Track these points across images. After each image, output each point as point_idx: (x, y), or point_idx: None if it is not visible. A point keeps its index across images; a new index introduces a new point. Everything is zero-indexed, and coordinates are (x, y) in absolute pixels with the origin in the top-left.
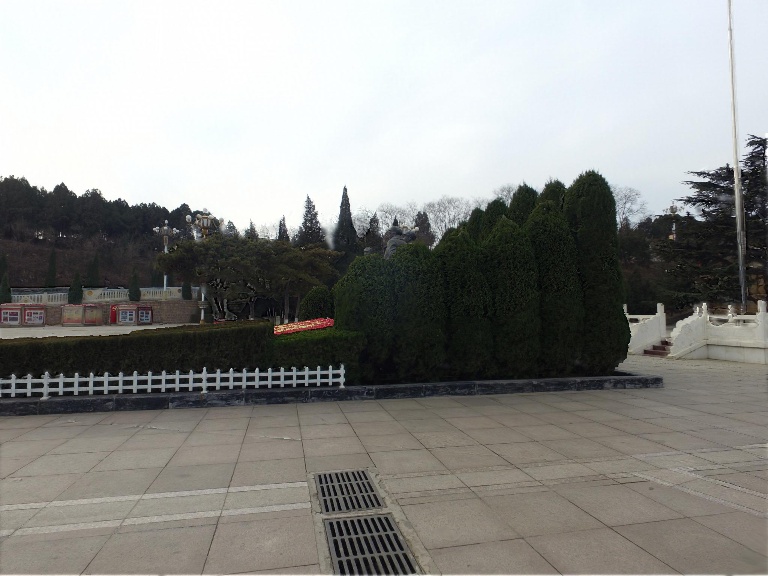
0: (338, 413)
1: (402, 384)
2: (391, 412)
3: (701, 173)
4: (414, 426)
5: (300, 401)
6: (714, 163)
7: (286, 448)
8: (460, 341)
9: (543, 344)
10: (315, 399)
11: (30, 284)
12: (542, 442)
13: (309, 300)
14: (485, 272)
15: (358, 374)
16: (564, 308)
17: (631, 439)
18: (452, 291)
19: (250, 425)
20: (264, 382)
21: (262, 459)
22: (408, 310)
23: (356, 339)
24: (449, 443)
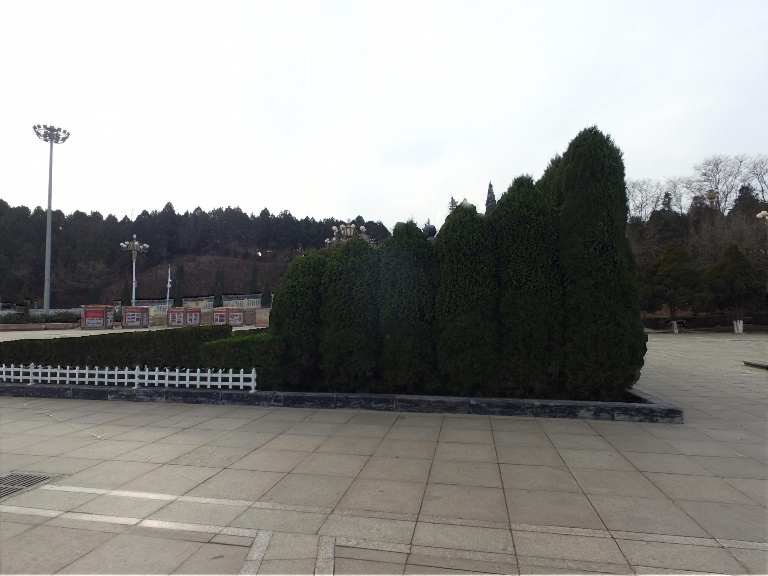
0: (209, 417)
1: (318, 393)
2: (255, 421)
3: None
4: (228, 439)
5: (212, 402)
6: None
7: (69, 446)
8: (389, 348)
9: (502, 355)
10: (225, 401)
11: (235, 292)
12: (291, 475)
13: None
14: (429, 268)
15: (280, 379)
16: (525, 309)
17: (404, 488)
18: (382, 291)
19: (113, 421)
20: (183, 382)
21: (25, 453)
22: (328, 313)
23: (272, 343)
24: (200, 461)
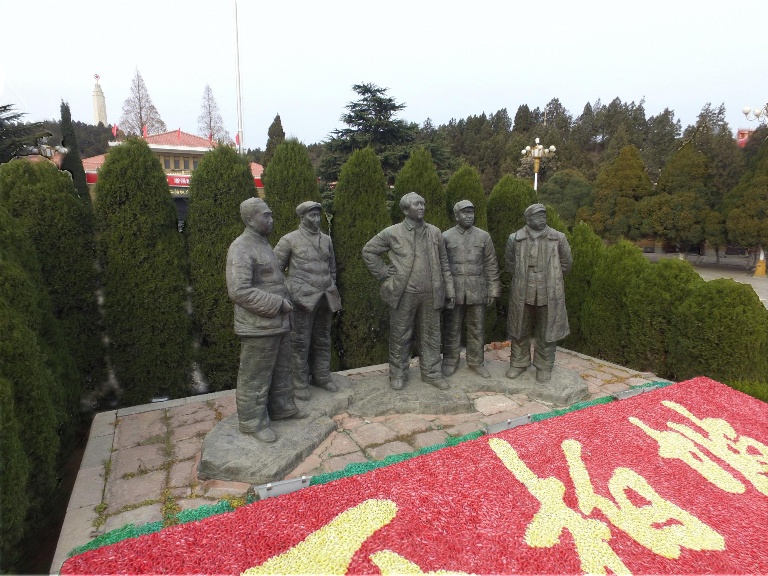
0: None
1: None
2: None
3: None
4: None
5: None
6: None
7: None
8: None
9: None
10: None
11: None
12: None
13: None
14: None
15: None
16: None
17: None
18: None
19: None
20: None
21: None
22: None
23: None
24: None
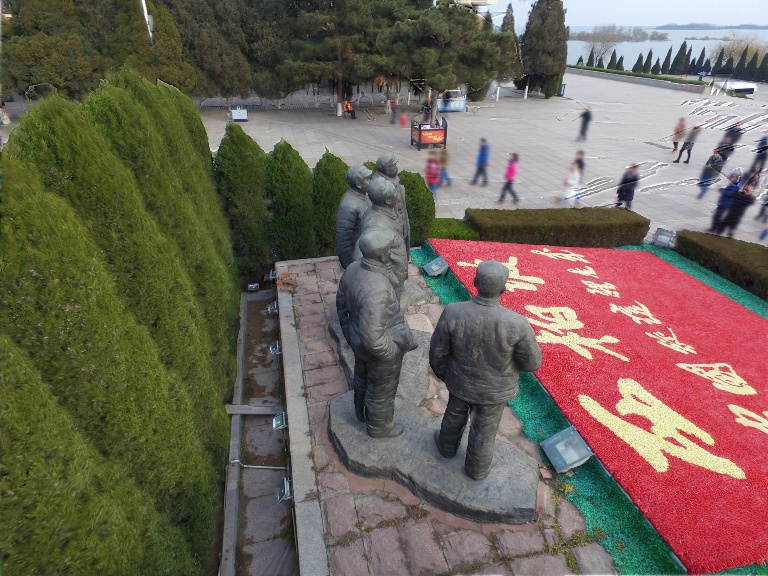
0: None
1: None
2: None
3: None
4: None
5: None
6: None
7: None
8: None
9: None
10: None
11: None
12: None
13: None
14: None
15: None
16: None
17: None
18: None
19: None
20: None
21: None
22: None
23: None
24: None
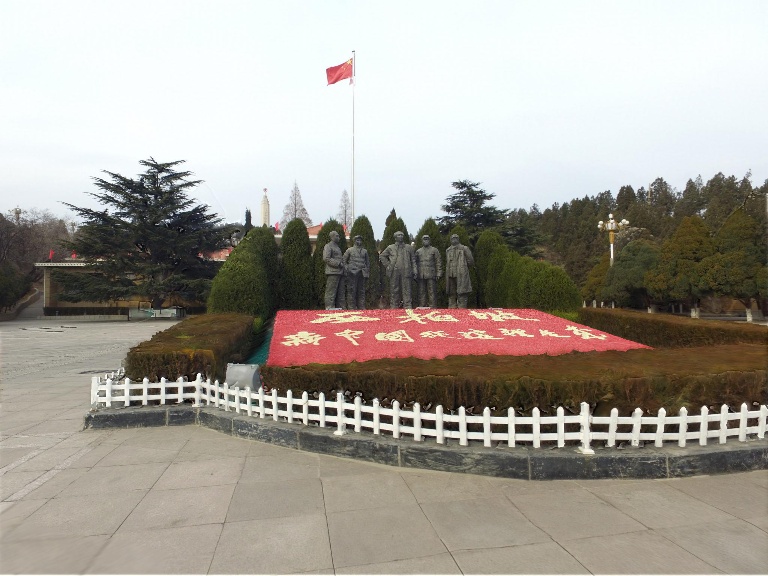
0: None
1: None
2: None
3: (116, 176)
4: None
5: None
6: (123, 170)
7: None
8: None
9: None
10: None
11: None
12: None
13: (255, 284)
14: None
15: None
16: None
17: None
18: None
19: None
20: None
21: None
22: None
23: None
24: None
